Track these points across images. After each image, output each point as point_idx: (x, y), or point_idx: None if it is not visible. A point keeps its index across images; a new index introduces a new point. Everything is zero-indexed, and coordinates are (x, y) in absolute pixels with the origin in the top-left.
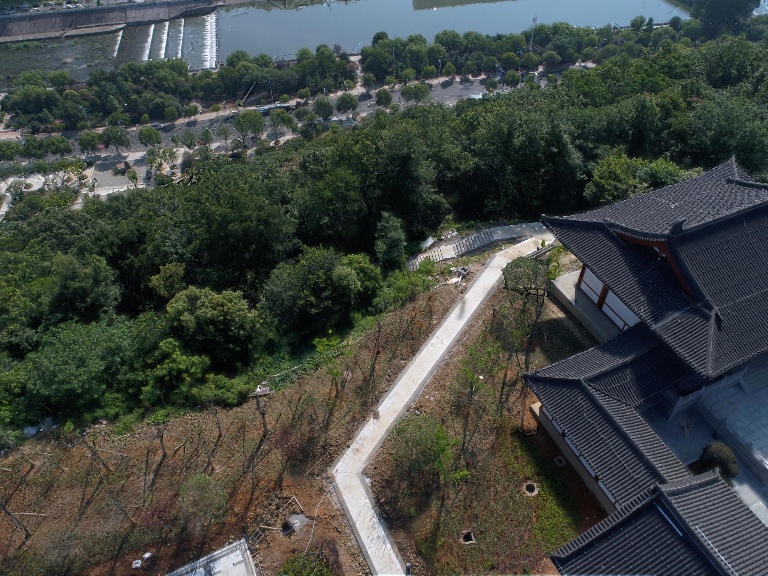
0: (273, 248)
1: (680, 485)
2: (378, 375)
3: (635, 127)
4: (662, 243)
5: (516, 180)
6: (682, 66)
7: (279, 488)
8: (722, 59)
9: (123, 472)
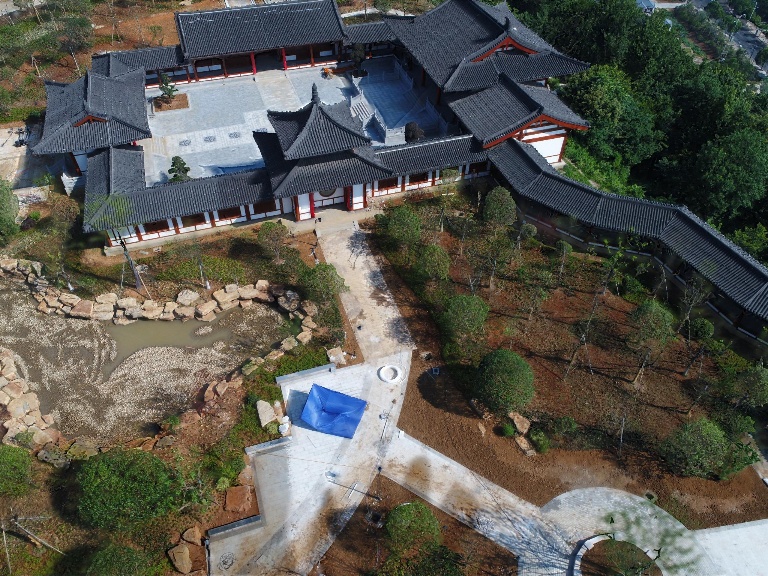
0: (524, 1)
1: (339, 17)
2: None
3: None
4: None
5: (624, 78)
6: None
7: None
8: None
9: None
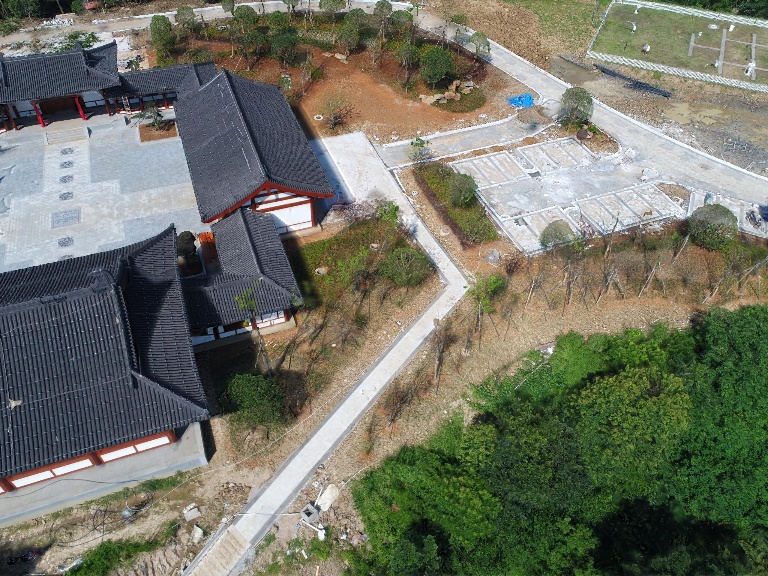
0: None
1: (240, 197)
2: None
3: None
4: None
5: None
6: None
7: (509, 272)
8: None
9: (634, 284)
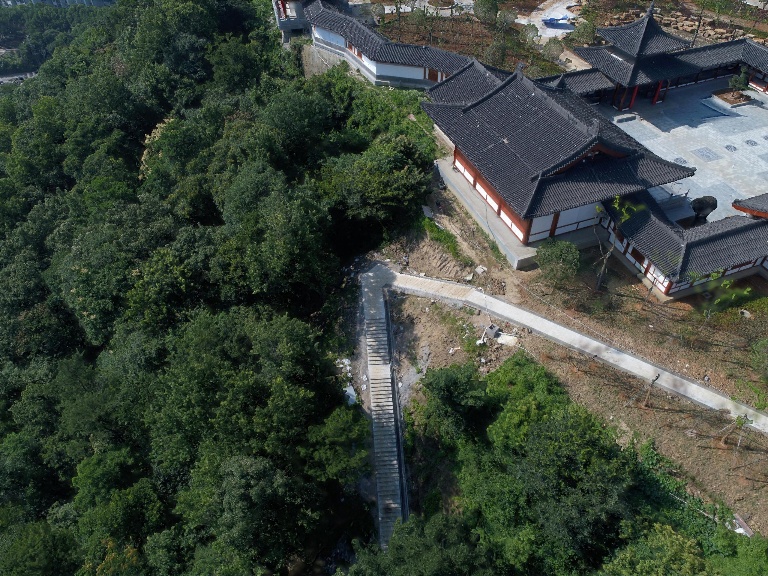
0: None
1: None
2: (678, 406)
3: (275, 160)
4: (596, 145)
5: None
6: (94, 124)
7: None
8: (113, 96)
9: None
